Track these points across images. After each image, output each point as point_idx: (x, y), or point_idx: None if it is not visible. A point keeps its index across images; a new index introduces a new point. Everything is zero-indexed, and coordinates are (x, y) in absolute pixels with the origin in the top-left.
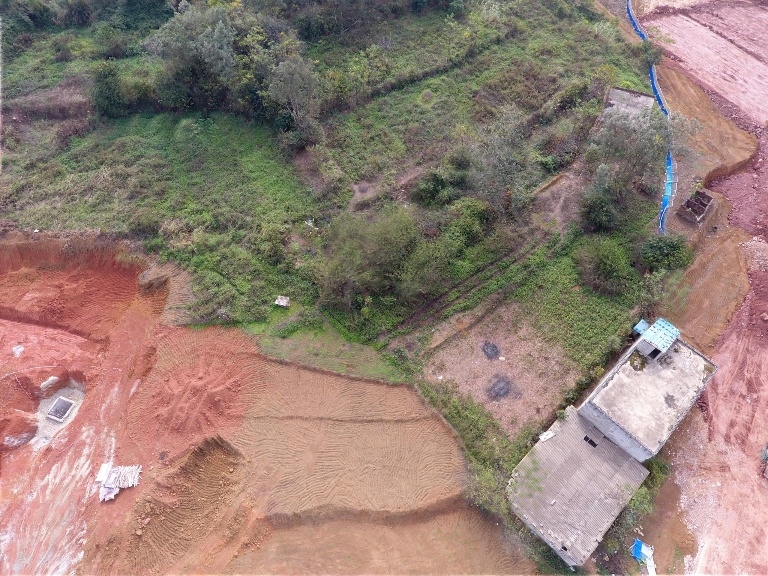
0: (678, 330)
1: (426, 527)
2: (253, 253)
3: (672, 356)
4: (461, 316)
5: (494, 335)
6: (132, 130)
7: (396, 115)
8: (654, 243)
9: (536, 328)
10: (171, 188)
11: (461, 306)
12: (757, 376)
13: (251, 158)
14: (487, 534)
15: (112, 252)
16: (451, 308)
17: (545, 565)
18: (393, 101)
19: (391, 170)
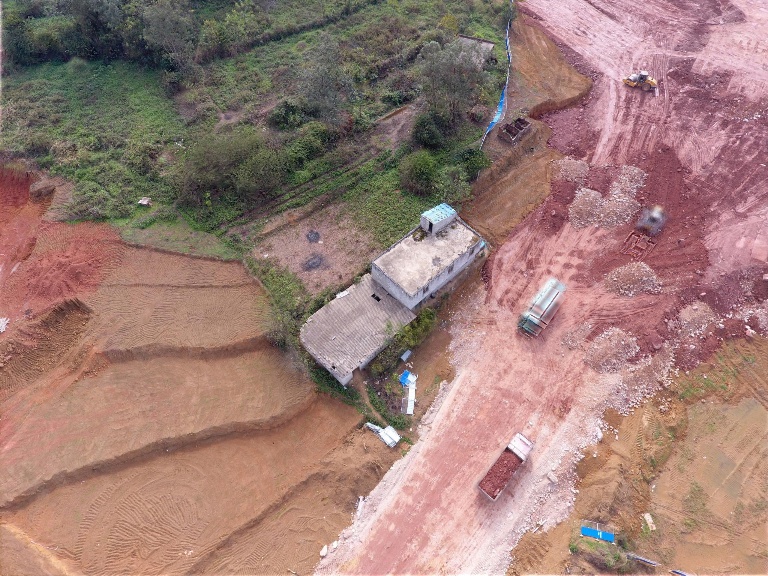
0: (454, 210)
1: (234, 361)
2: (128, 166)
3: (448, 231)
4: (293, 211)
5: (319, 225)
6: (41, 75)
7: (269, 60)
8: (462, 153)
9: (355, 220)
10: (66, 118)
11: (293, 203)
12: (537, 257)
13: (139, 95)
14: (282, 364)
15: (11, 169)
16: (285, 205)
17: (324, 385)
18: (269, 49)
19: (256, 102)
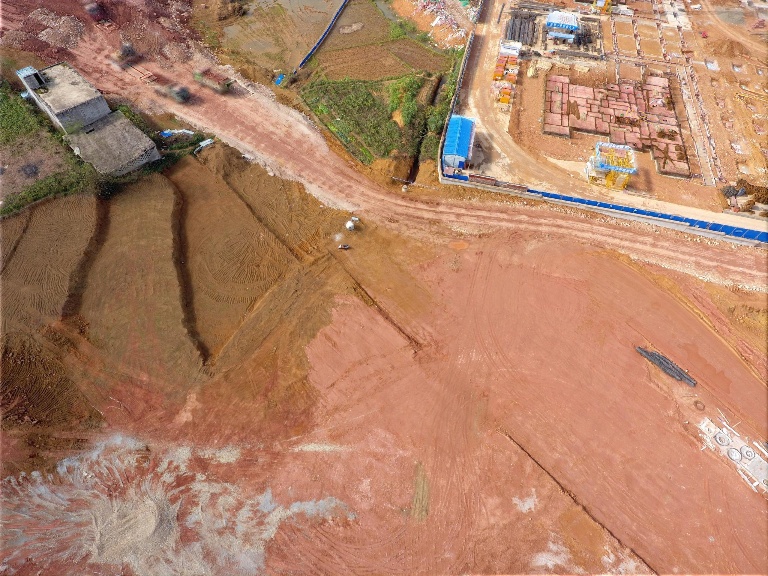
0: (29, 66)
1: (113, 222)
2: None
3: (47, 76)
4: None
5: None
6: None
7: None
8: None
9: None
10: None
11: None
12: (92, 67)
13: None
14: (130, 192)
15: None
16: None
17: (157, 169)
18: None
19: None
